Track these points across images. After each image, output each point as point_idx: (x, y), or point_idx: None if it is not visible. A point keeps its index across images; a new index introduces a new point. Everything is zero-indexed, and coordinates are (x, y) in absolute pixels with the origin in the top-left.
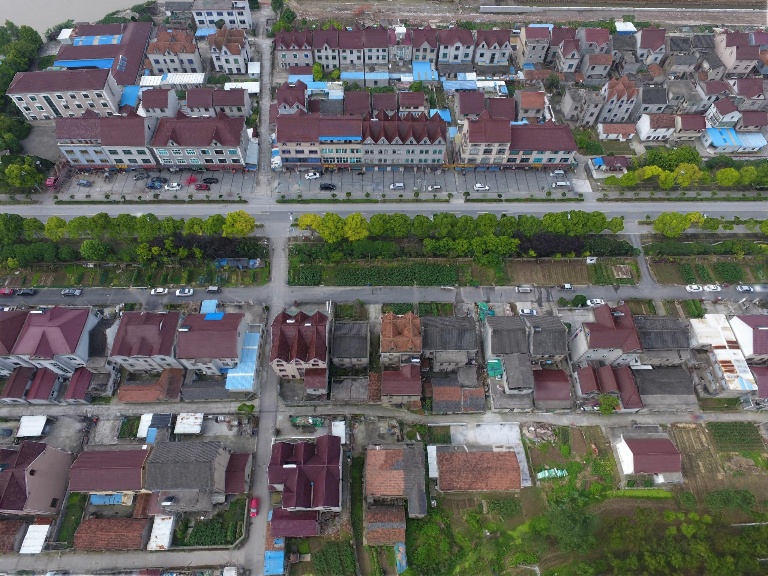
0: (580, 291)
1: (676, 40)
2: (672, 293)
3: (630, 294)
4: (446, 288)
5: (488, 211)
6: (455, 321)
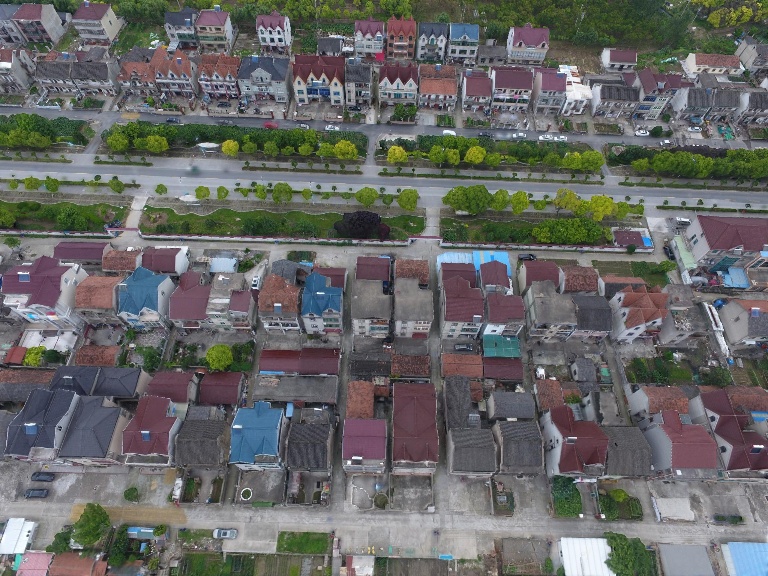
0: (652, 143)
1: (528, 438)
2: (578, 138)
3: (612, 139)
4: (762, 148)
5: (750, 202)
6: (764, 102)
